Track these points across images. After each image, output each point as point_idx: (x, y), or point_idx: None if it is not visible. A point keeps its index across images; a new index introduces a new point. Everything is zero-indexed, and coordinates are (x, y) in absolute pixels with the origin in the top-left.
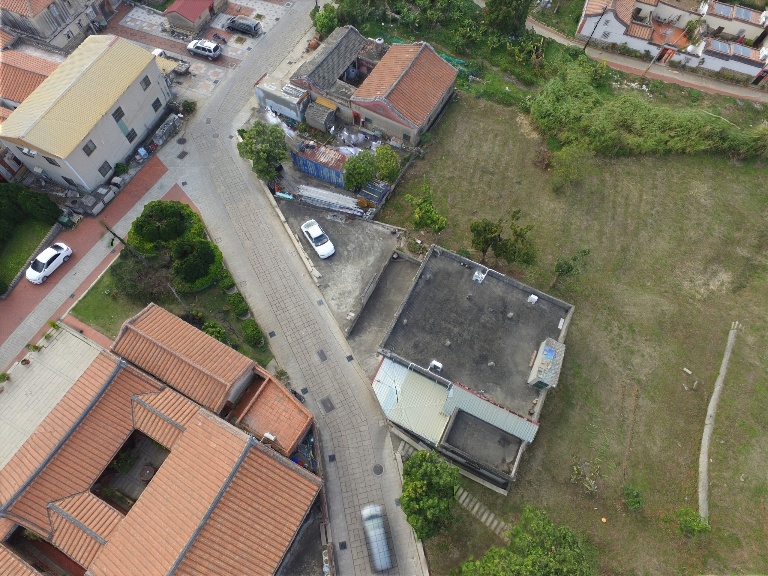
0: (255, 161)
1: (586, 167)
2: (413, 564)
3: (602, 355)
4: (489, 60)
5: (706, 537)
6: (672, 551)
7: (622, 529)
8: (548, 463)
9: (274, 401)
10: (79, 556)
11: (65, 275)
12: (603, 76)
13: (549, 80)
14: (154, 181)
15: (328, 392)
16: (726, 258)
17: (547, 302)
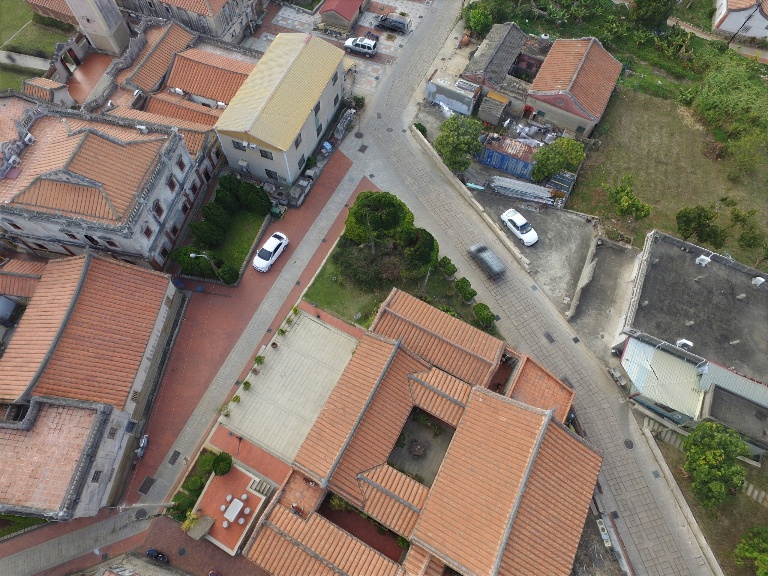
0: (450, 153)
1: None
2: (685, 532)
3: None
4: (637, 55)
5: None
6: None
7: None
8: None
9: (535, 379)
10: (393, 523)
11: (286, 263)
12: (755, 69)
13: (700, 73)
14: (343, 174)
15: (564, 372)
16: None
17: None
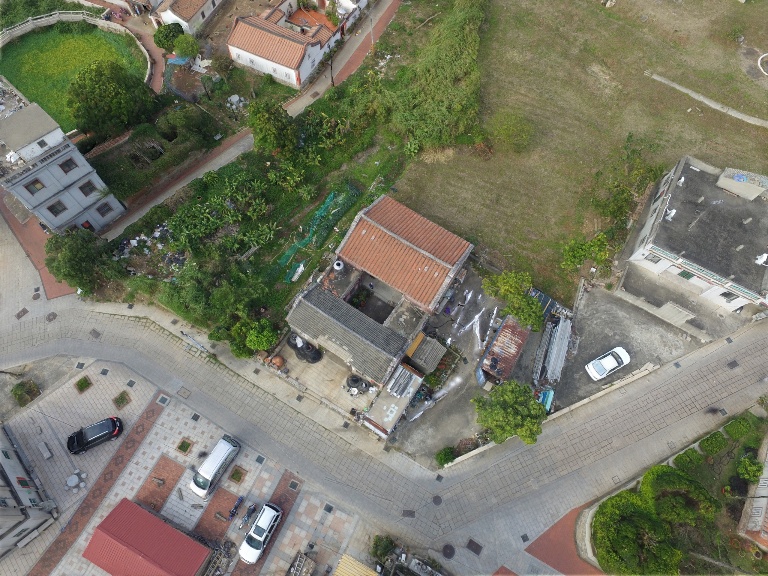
0: None
1: None
2: None
3: None
4: (332, 170)
5: None
6: None
7: None
8: None
9: None
10: None
11: None
12: (381, 80)
13: None
14: None
15: (766, 361)
16: (582, 61)
17: None
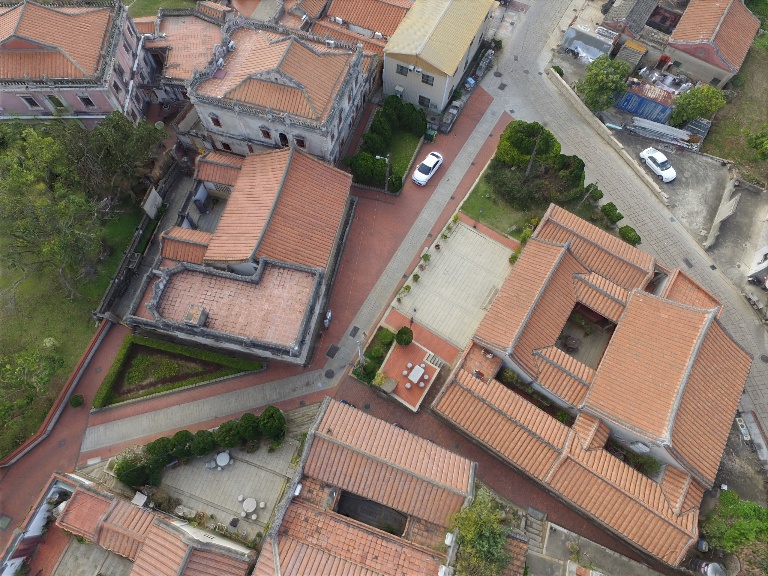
0: (595, 92)
1: None
2: None
3: None
4: (767, 17)
5: None
6: None
7: None
8: None
9: (686, 290)
10: (564, 394)
11: (440, 180)
12: None
13: None
14: (485, 107)
15: None
16: None
17: None
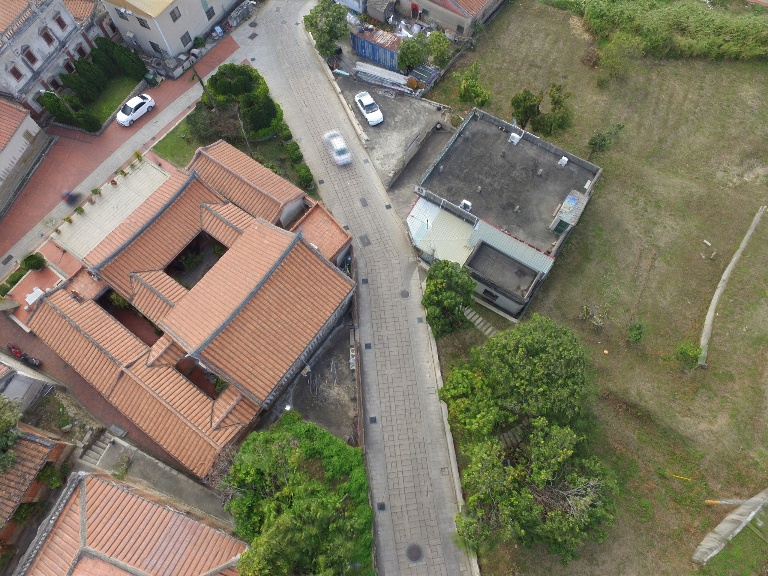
0: (318, 37)
1: (634, 66)
2: (428, 367)
3: (625, 223)
4: None
5: (701, 374)
6: (667, 381)
7: (622, 360)
8: (560, 303)
9: (320, 222)
10: (153, 315)
11: (148, 122)
12: None
13: None
14: (227, 55)
15: (366, 231)
16: (765, 154)
17: (577, 166)
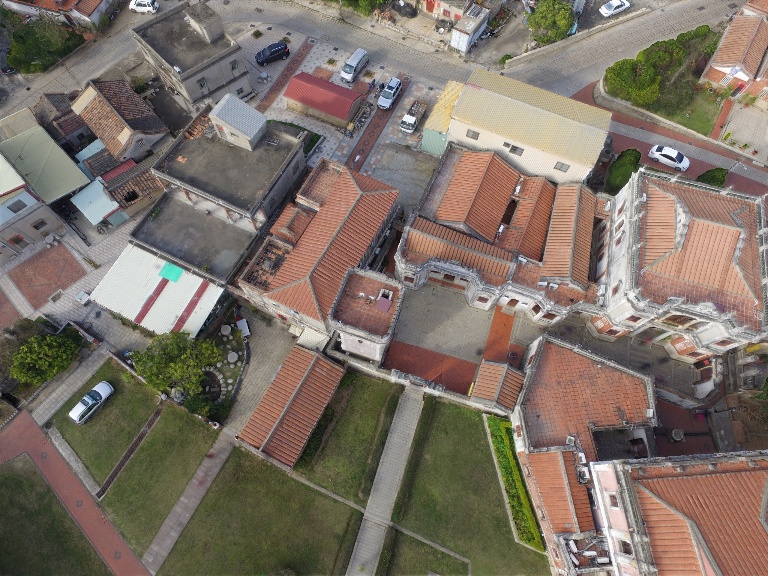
0: None
1: None
2: None
3: None
4: None
5: None
6: None
7: None
8: None
9: (760, 4)
10: None
11: None
12: None
13: None
14: None
15: (725, 6)
16: None
17: None
